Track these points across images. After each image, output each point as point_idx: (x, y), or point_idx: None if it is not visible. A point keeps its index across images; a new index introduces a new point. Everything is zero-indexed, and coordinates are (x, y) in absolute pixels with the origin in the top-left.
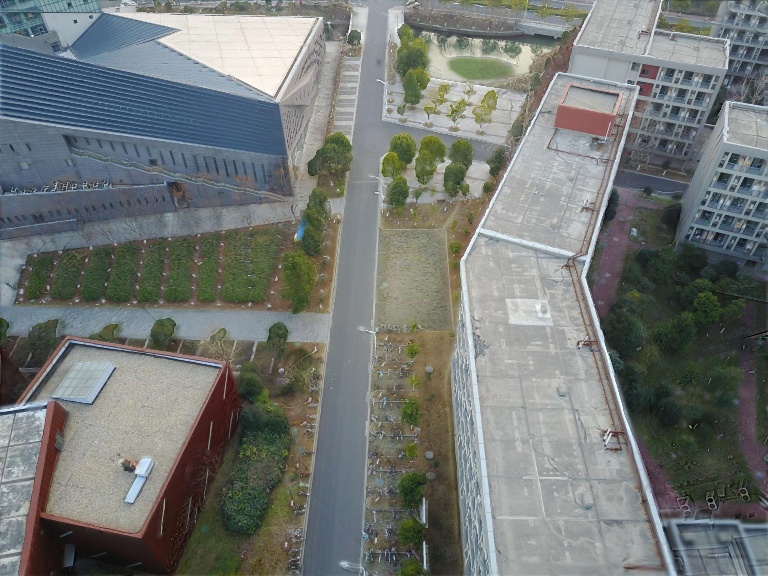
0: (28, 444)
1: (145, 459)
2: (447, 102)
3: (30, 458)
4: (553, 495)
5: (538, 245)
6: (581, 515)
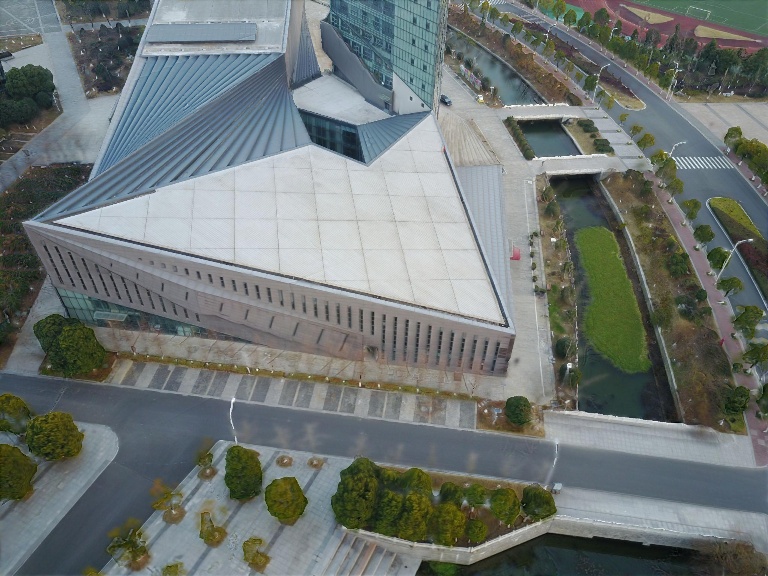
0: None
1: None
2: (250, 568)
3: None
4: None
5: None
6: None
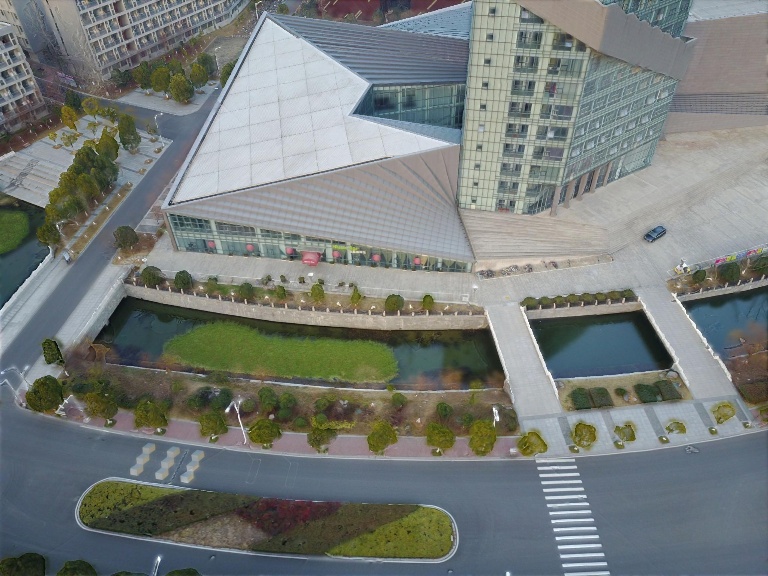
0: None
1: None
2: None
3: None
4: None
5: None
6: None
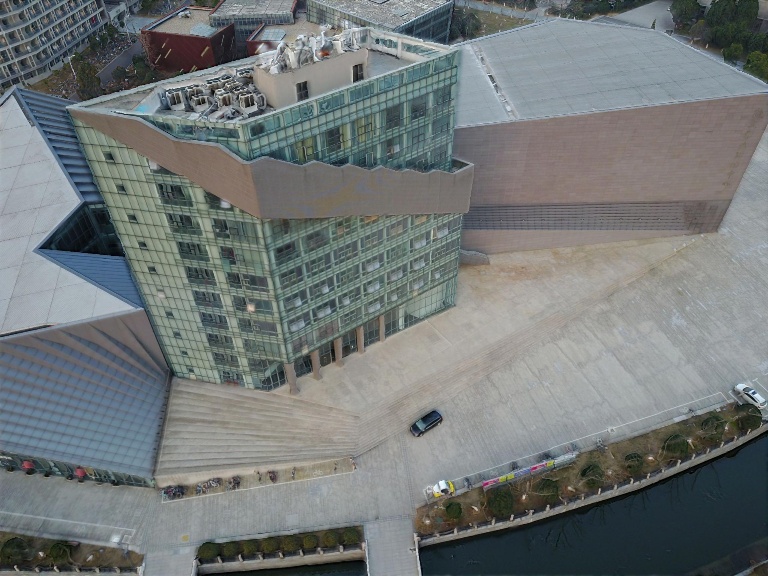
0: None
1: (180, 14)
2: None
3: None
4: None
5: None
6: None
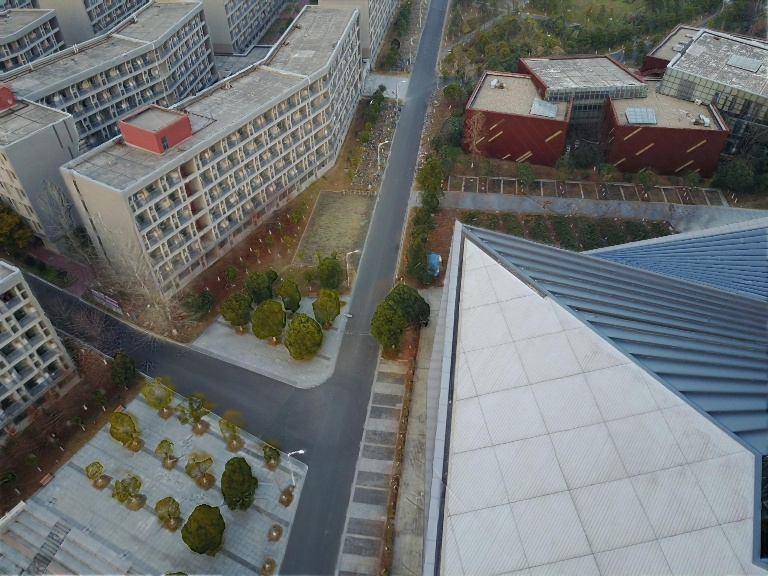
0: None
1: (494, 84)
2: None
3: None
4: (329, 19)
5: (278, 70)
6: (322, 17)
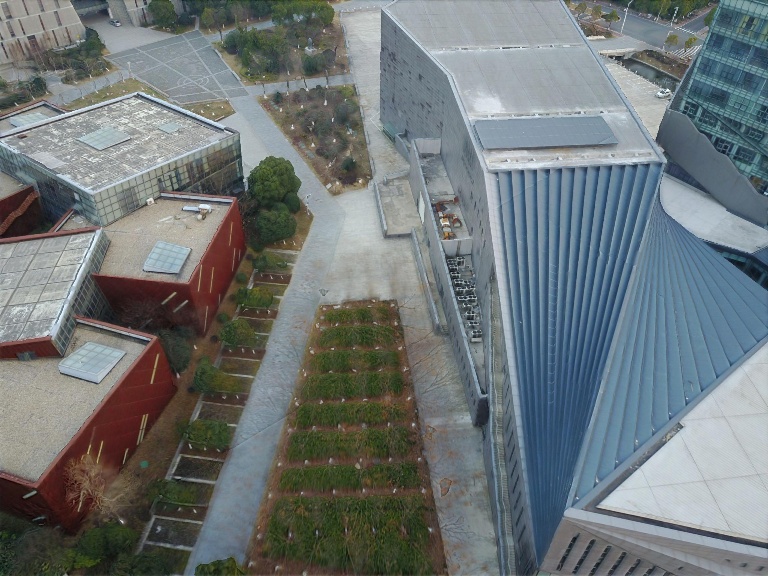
0: (20, 334)
1: None
2: None
3: (6, 338)
4: None
5: None
6: None
